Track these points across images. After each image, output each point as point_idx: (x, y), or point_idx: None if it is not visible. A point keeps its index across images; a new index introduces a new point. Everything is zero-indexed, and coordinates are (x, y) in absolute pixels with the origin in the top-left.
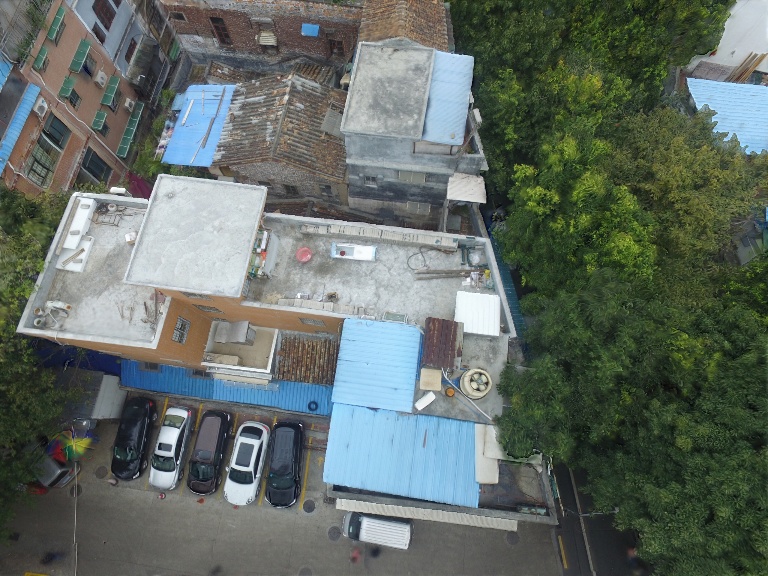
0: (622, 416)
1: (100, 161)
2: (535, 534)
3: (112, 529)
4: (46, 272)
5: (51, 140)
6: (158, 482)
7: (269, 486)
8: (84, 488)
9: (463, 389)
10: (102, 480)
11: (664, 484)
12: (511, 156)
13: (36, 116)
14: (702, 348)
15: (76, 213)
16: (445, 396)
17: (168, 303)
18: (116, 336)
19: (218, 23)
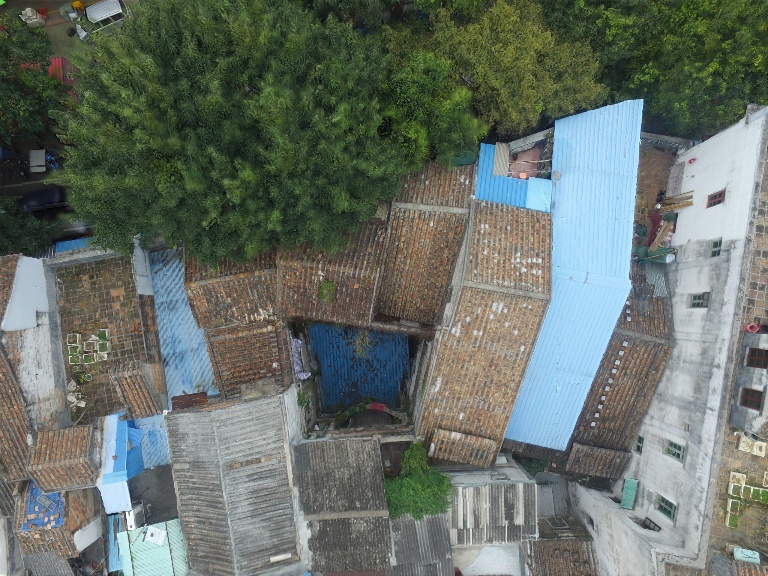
0: None
1: None
2: None
3: None
4: None
5: None
6: None
7: None
8: None
9: None
10: None
11: None
12: None
13: None
14: None
15: None
16: None
17: None
18: None
19: None
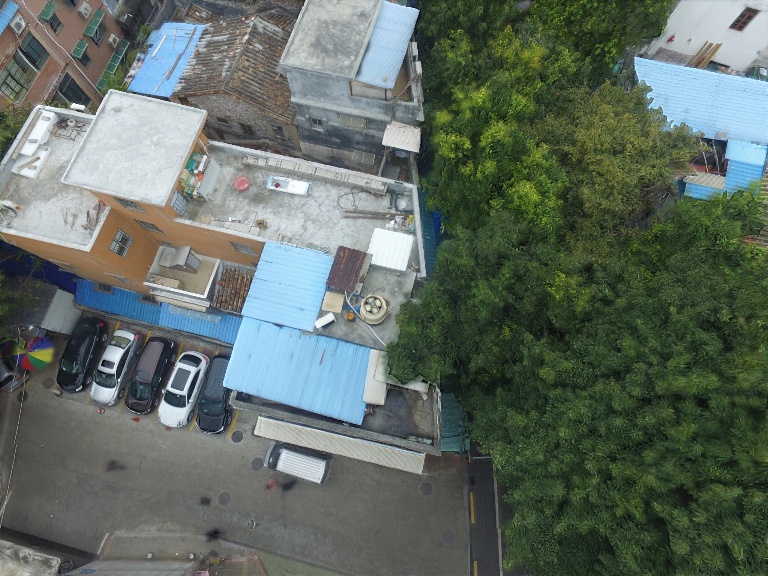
0: (503, 352)
1: (78, 89)
2: (448, 488)
3: (51, 436)
4: (1, 173)
5: (28, 59)
6: (99, 397)
7: (200, 411)
8: (30, 395)
9: (362, 314)
10: (48, 390)
11: None
12: None
13: (12, 32)
14: (575, 288)
15: (37, 124)
16: (347, 321)
17: (107, 212)
18: (56, 237)
19: None
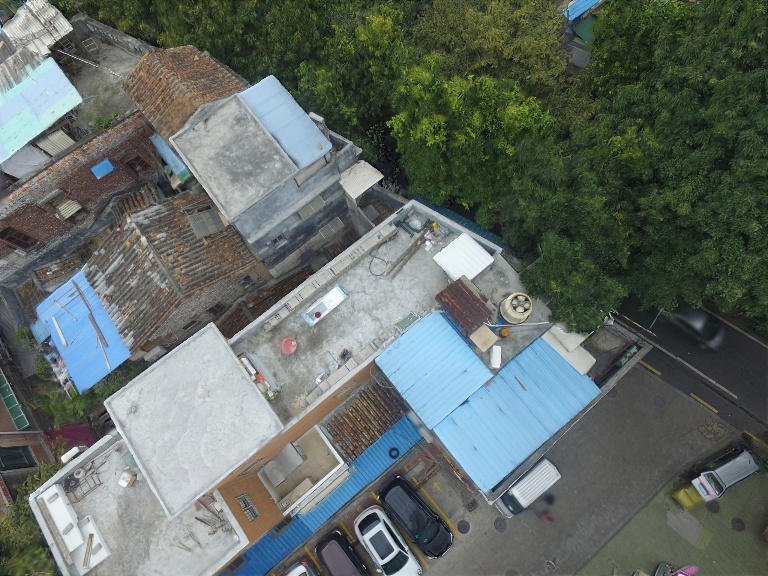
0: None
1: (10, 450)
2: None
3: None
4: None
5: None
6: None
7: (423, 546)
8: None
9: (511, 321)
10: None
11: (693, 249)
12: (360, 128)
13: None
14: (636, 136)
15: (50, 512)
16: (503, 339)
17: (219, 497)
18: (202, 571)
19: (8, 234)
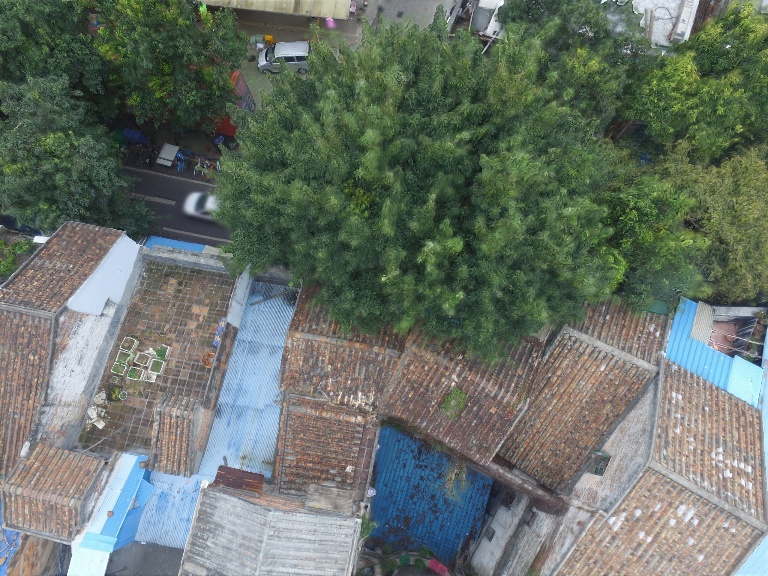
0: None
1: None
2: None
3: None
4: None
5: None
6: None
7: None
8: None
9: None
10: None
11: None
12: None
13: None
14: None
15: None
16: None
17: None
18: None
19: None
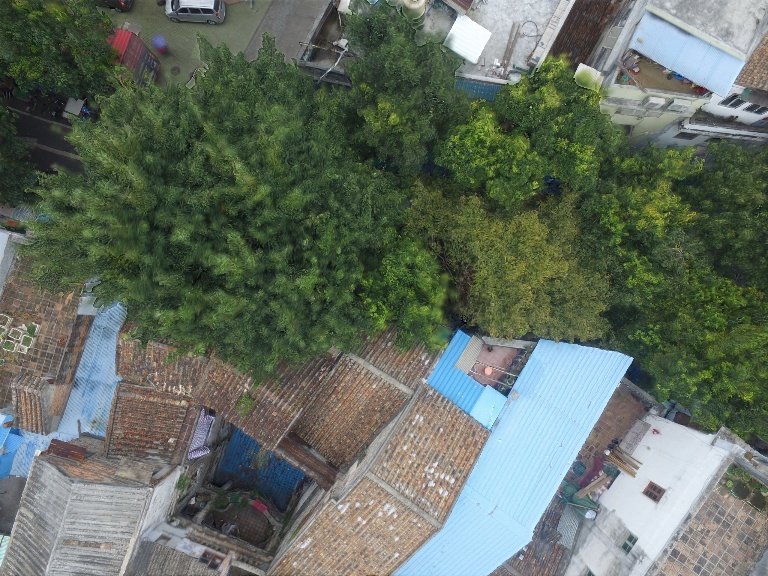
0: None
1: None
2: None
3: None
4: None
5: None
6: None
7: None
8: None
9: None
10: None
11: None
12: (606, 173)
13: None
14: (379, 126)
15: None
16: None
17: None
18: None
19: None
